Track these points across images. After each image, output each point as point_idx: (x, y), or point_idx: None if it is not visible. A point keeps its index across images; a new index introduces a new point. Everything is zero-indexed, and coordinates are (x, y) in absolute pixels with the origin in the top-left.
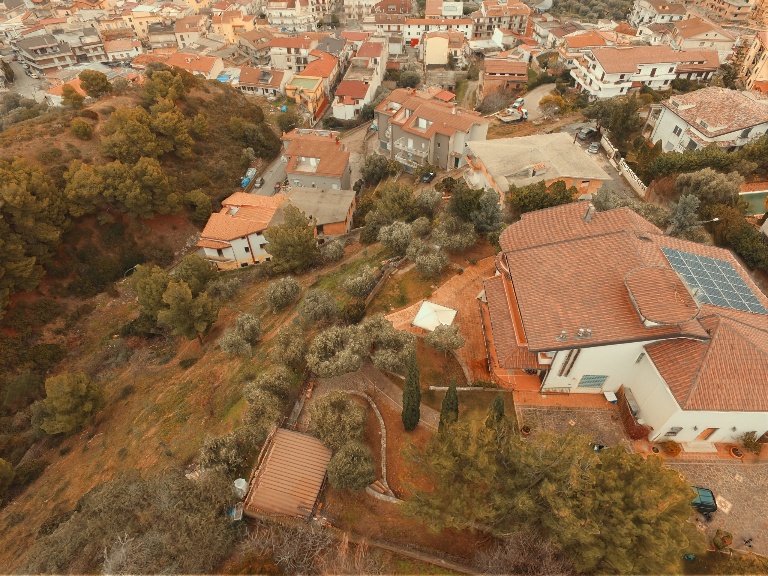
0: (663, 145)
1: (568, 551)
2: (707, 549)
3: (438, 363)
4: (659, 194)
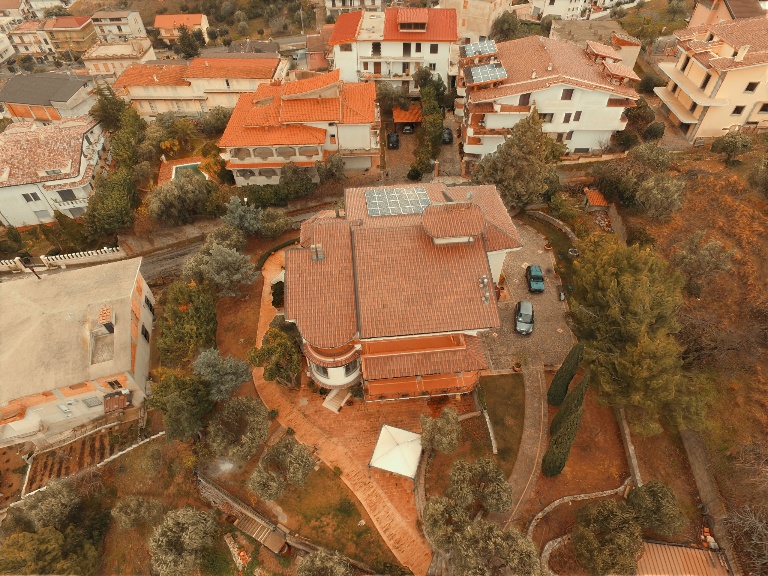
0: (33, 219)
1: (674, 316)
2: (560, 280)
3: (459, 447)
4: (148, 237)
